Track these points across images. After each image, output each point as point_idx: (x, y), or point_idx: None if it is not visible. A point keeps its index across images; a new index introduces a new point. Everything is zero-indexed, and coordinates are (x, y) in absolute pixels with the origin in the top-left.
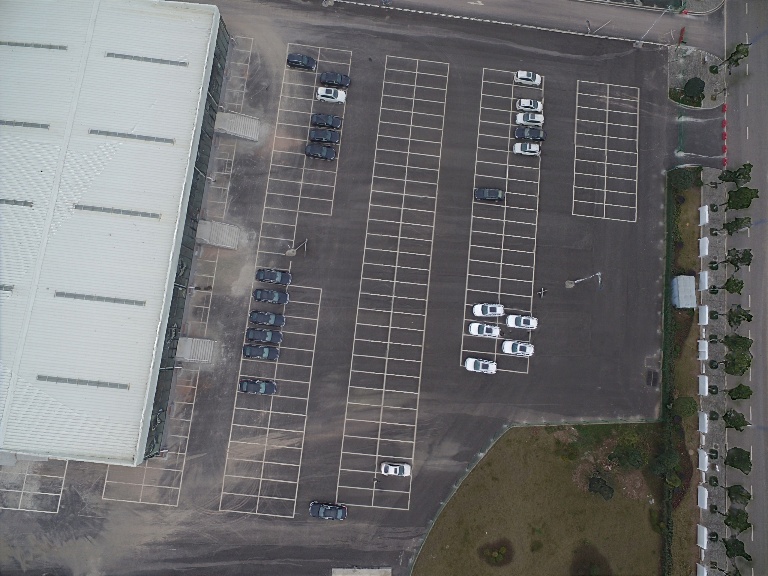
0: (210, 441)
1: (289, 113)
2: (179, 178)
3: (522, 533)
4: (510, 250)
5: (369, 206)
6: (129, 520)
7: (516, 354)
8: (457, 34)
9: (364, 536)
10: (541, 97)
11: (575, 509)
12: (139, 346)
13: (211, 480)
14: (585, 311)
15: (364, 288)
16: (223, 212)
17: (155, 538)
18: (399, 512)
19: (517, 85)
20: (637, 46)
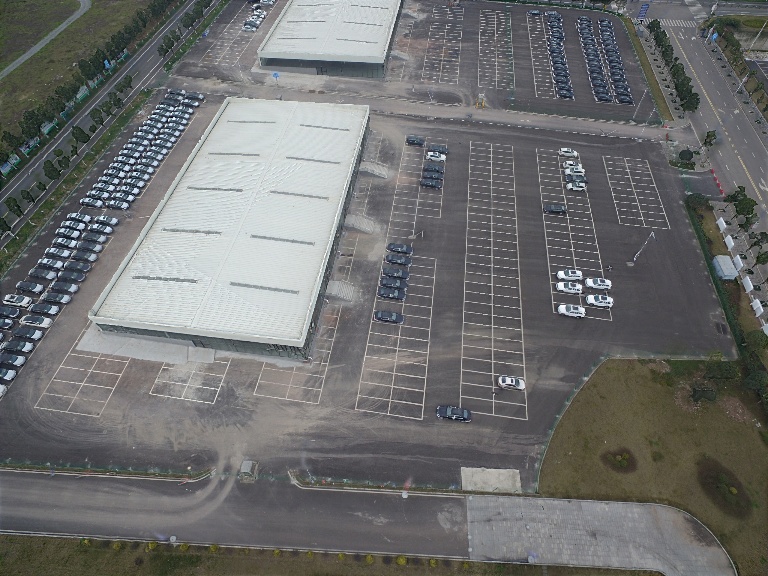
0: (349, 355)
1: (408, 166)
2: (342, 180)
3: (640, 444)
4: (577, 242)
5: (467, 214)
6: (275, 413)
7: (599, 306)
8: (515, 133)
9: (489, 440)
10: (579, 163)
11: (686, 427)
12: (308, 268)
13: (349, 385)
14: (648, 281)
15: (469, 260)
16: (362, 213)
17: (297, 429)
18: (519, 421)
19: (561, 157)
20: (638, 141)
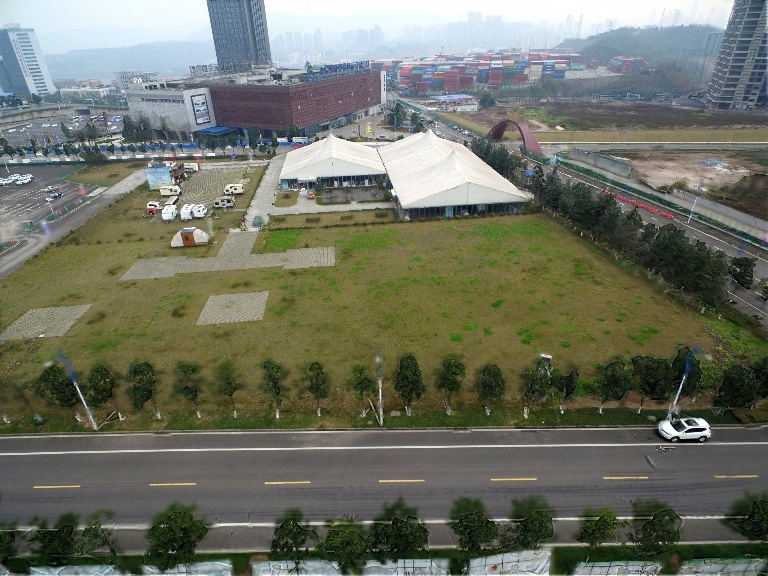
0: None
1: None
2: None
3: None
4: None
5: None
6: None
7: None
8: None
9: None
10: None
11: None
12: None
13: None
14: None
15: None
16: None
17: None
18: None
19: None
20: None
